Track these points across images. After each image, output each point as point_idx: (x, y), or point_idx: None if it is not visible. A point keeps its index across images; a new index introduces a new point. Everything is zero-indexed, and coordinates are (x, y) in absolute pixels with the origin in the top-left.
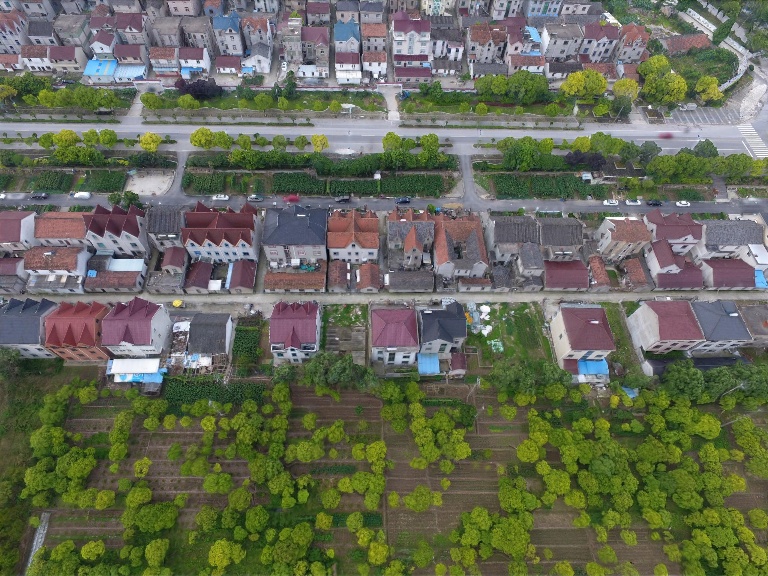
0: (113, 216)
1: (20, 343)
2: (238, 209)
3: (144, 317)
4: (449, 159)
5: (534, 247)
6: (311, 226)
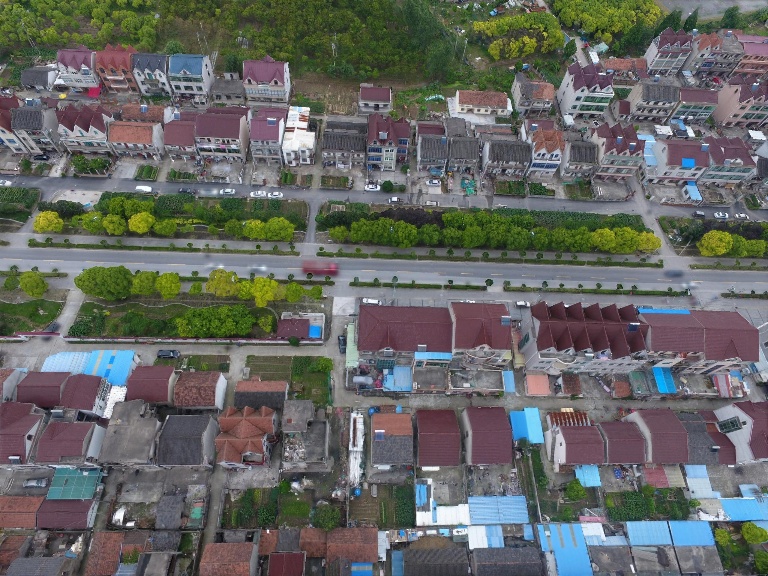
0: (75, 112)
1: (153, 53)
2: None
3: (63, 53)
4: None
5: None
6: None
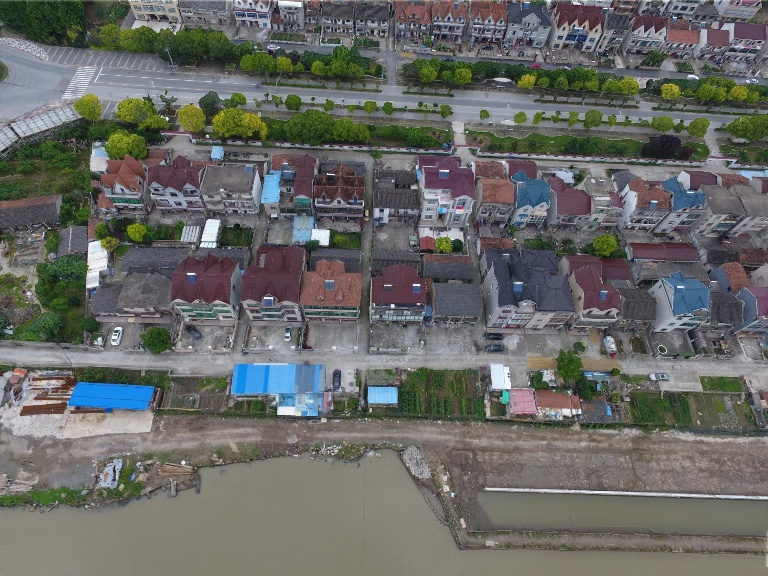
0: (649, 17)
1: None
2: (574, 64)
3: None
4: (411, 66)
5: (362, 1)
6: (518, 6)
